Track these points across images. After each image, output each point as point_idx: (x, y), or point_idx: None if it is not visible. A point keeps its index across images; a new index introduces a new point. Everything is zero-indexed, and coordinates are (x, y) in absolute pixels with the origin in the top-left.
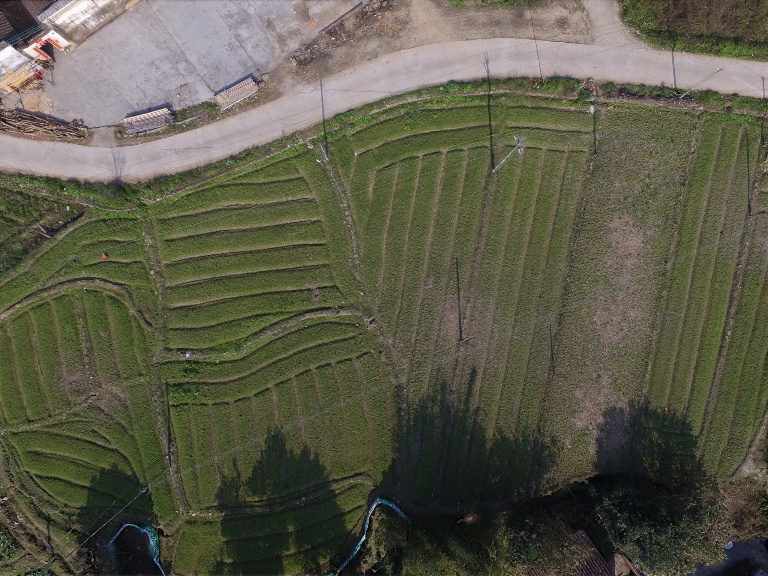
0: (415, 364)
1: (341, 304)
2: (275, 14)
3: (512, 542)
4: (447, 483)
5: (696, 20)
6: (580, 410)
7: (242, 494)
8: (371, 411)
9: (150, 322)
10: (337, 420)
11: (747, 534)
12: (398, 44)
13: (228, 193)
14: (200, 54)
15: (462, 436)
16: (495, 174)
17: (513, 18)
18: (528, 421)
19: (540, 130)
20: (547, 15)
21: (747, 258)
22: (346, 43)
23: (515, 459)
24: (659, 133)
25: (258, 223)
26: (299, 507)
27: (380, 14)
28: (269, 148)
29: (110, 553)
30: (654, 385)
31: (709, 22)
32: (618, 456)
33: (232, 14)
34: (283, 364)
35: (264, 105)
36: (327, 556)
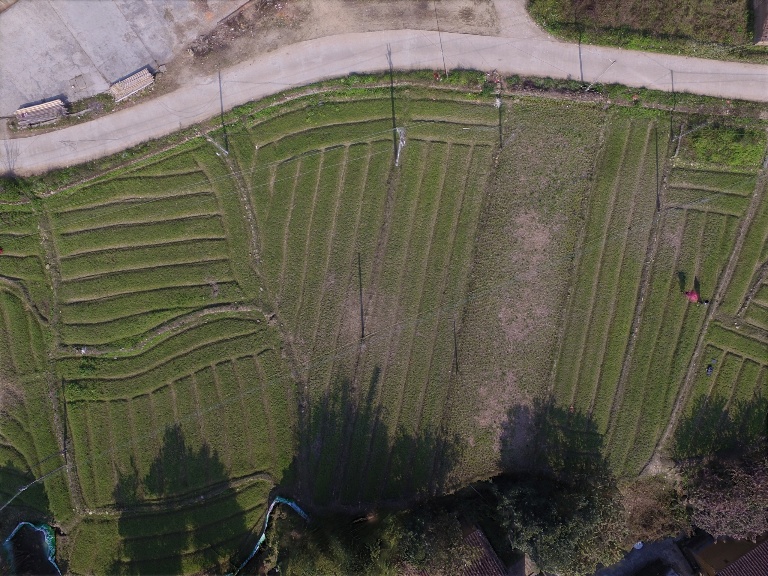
0: (316, 361)
1: (241, 300)
2: (173, 4)
3: (401, 542)
4: (348, 482)
5: (604, 12)
6: (484, 408)
7: (140, 492)
8: (272, 408)
9: (46, 317)
10: (237, 417)
11: (656, 534)
12: (298, 35)
13: (125, 186)
14: (96, 44)
15: (363, 434)
16: (398, 168)
17: (417, 9)
18: (431, 419)
19: (445, 123)
20: (451, 6)
21: (656, 254)
22: (245, 34)
23: (417, 457)
24: (566, 127)
25: (156, 217)
26: (199, 505)
27: (280, 4)
28: (166, 141)
29: (9, 552)
30: (560, 383)
31: (618, 14)
32: (522, 455)
33: (128, 4)
34: (182, 360)
35: (161, 97)
36: (227, 555)
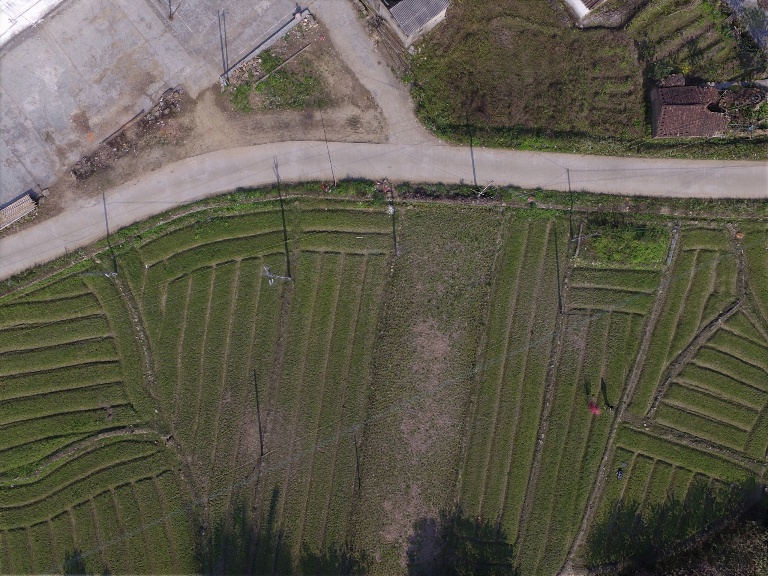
0: (215, 482)
1: (136, 422)
2: (54, 127)
3: None
4: None
5: (497, 112)
6: (389, 522)
7: None
8: (173, 531)
9: None
10: (137, 542)
11: None
12: (183, 152)
13: (14, 313)
14: None
15: (266, 554)
16: (291, 281)
17: (303, 119)
18: (334, 536)
19: (337, 234)
20: (338, 115)
21: (560, 357)
22: (128, 153)
23: None
24: (462, 231)
25: (47, 342)
26: None
27: (163, 121)
28: (51, 266)
29: None
30: (466, 493)
31: (511, 113)
32: (430, 569)
33: (9, 129)
34: (79, 486)
35: (45, 222)
36: None
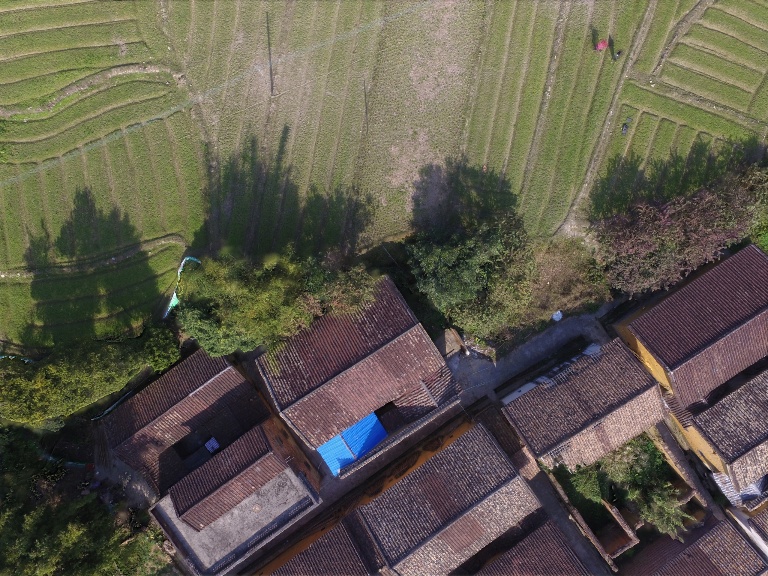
0: (225, 120)
1: (149, 60)
2: None
3: (301, 271)
4: (259, 241)
5: None
6: (395, 167)
7: (51, 255)
8: (182, 171)
9: None
10: (147, 180)
11: (574, 300)
12: None
13: None
14: None
15: (274, 193)
16: None
17: None
18: (341, 178)
19: None
20: None
21: (569, 13)
22: None
23: (328, 217)
24: None
25: None
26: (111, 270)
27: None
28: None
29: None
30: (472, 142)
31: None
32: (435, 214)
33: None
34: (91, 123)
35: None
36: (139, 318)
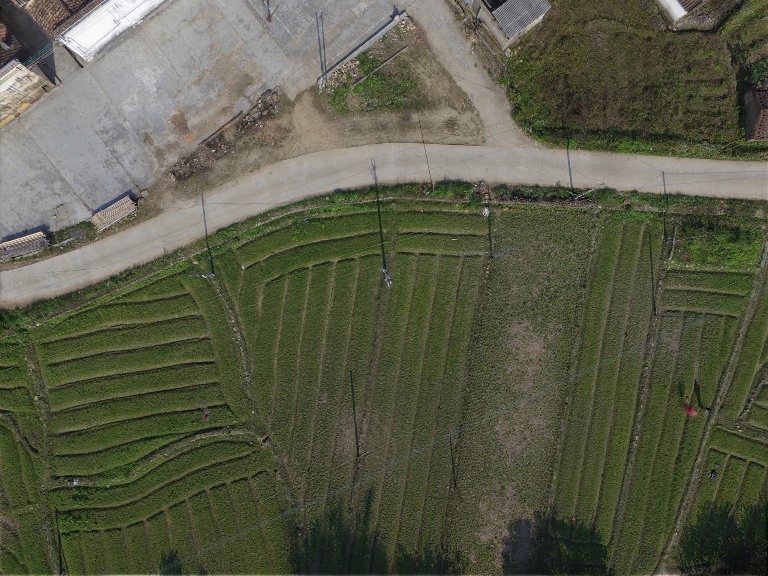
0: (311, 482)
1: (233, 423)
2: (152, 128)
3: None
4: None
5: (592, 114)
6: (484, 523)
7: None
8: (268, 531)
9: (36, 449)
10: (233, 542)
11: None
12: (281, 154)
13: (111, 314)
14: (76, 173)
15: (362, 555)
16: None
17: (400, 121)
18: (430, 537)
19: (433, 235)
20: (435, 117)
21: (653, 359)
22: (227, 155)
23: None
24: (557, 233)
25: (144, 343)
26: None
27: (262, 123)
28: (150, 267)
29: None
30: (560, 495)
31: (606, 116)
32: (525, 570)
33: (108, 130)
34: (175, 487)
35: (144, 223)
36: None
